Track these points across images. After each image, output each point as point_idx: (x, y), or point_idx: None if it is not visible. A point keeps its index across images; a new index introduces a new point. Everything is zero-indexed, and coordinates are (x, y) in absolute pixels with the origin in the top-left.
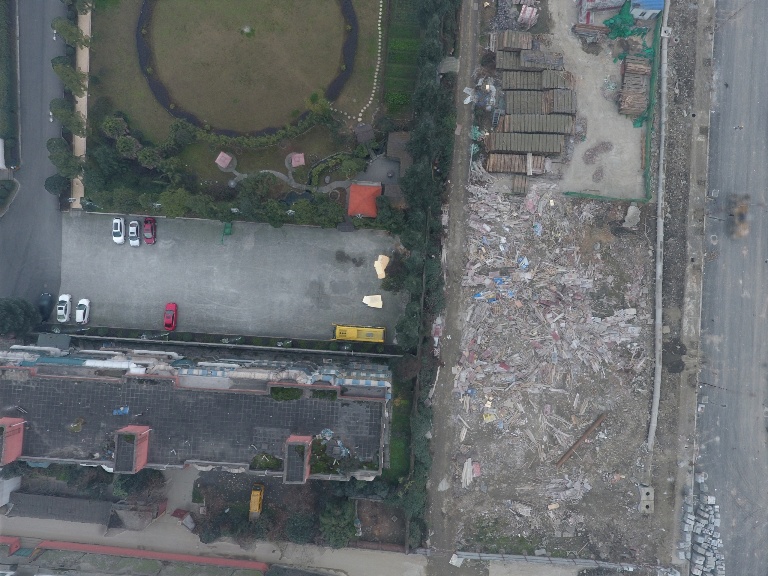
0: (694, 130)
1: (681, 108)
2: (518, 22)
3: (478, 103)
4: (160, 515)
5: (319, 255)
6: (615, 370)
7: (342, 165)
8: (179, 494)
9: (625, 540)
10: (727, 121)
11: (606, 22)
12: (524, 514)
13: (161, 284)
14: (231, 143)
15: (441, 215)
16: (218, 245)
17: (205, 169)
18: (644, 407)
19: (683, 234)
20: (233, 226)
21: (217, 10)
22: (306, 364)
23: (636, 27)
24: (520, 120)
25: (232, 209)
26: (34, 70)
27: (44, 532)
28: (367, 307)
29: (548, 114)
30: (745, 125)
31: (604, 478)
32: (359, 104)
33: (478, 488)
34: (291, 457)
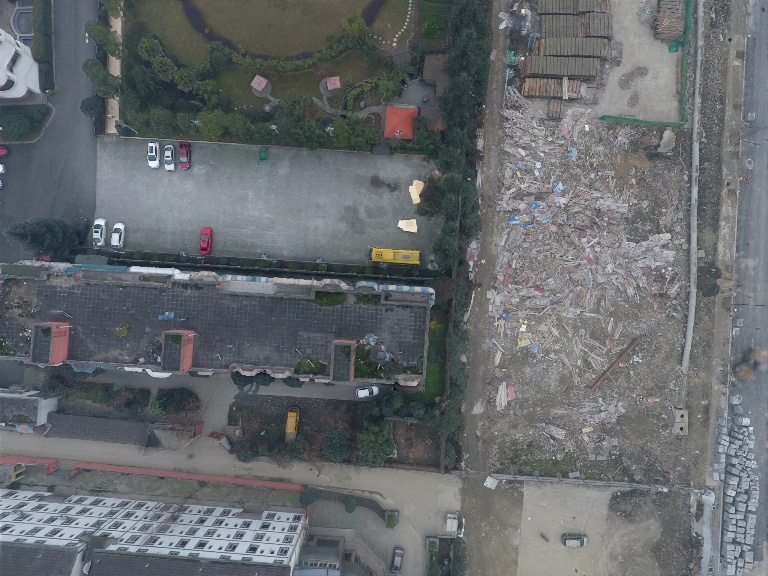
0: (730, 54)
1: (717, 32)
2: None
3: (514, 27)
4: (197, 436)
5: (354, 180)
6: (649, 295)
7: None
8: (215, 417)
9: (659, 463)
10: (763, 45)
11: None
12: (558, 437)
13: (196, 209)
14: (267, 66)
15: (476, 139)
16: (253, 170)
17: (239, 94)
18: (678, 331)
19: (719, 158)
20: (268, 151)
21: None
22: None
23: None
24: (556, 43)
25: (271, 126)
26: None
27: (81, 454)
28: (402, 232)
29: (584, 38)
30: None
31: (638, 402)
32: (394, 29)
33: (512, 411)
34: (337, 358)
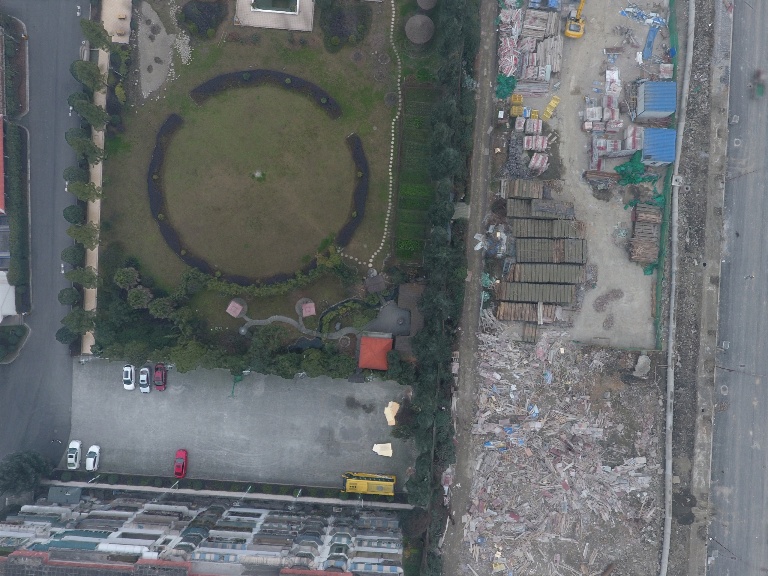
0: (705, 280)
1: (692, 257)
2: (529, 168)
3: (489, 251)
4: None
5: (329, 401)
6: (625, 519)
7: (353, 318)
8: None
9: None
10: (738, 270)
11: (617, 169)
12: None
13: (171, 430)
14: (242, 293)
15: (451, 363)
16: (228, 391)
17: (216, 314)
18: (654, 558)
19: (693, 384)
20: None
21: (228, 154)
22: (316, 520)
23: (647, 175)
24: (531, 270)
25: (243, 371)
26: (45, 214)
27: None
28: (377, 454)
29: (559, 263)
30: (756, 275)
31: None
32: (370, 249)
33: None
34: None
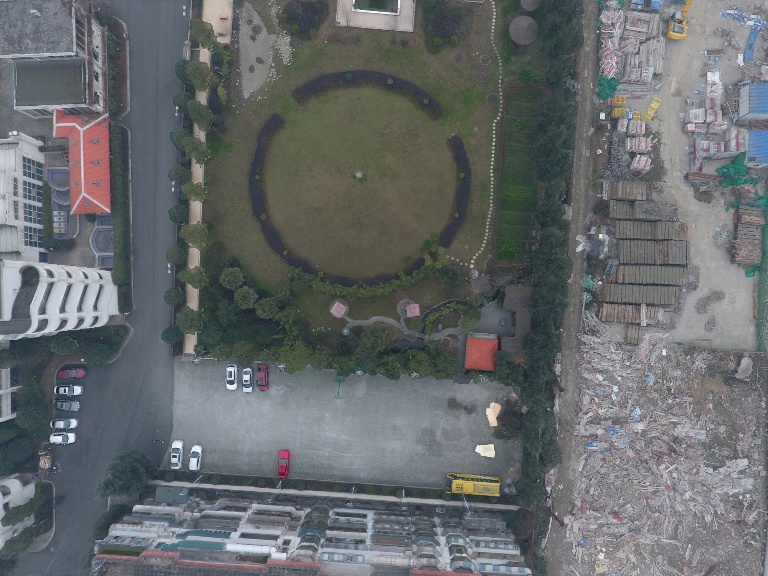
0: None
1: None
2: (631, 170)
3: (592, 252)
4: None
5: (431, 402)
6: (727, 521)
7: None
8: None
9: None
10: None
11: (718, 170)
12: None
13: (273, 430)
14: (347, 293)
15: (554, 365)
16: (330, 391)
17: (317, 315)
18: (757, 560)
19: None
20: None
21: (329, 155)
22: (424, 521)
23: (749, 177)
24: (635, 272)
25: (357, 372)
26: (146, 214)
27: None
28: (479, 455)
29: (662, 265)
30: None
31: None
32: (471, 250)
33: None
34: None
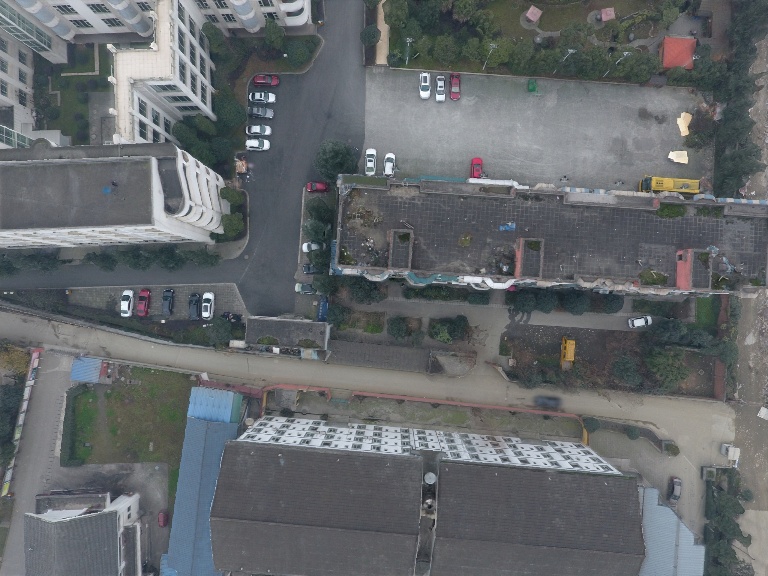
0: None
1: None
2: None
3: None
4: None
5: (622, 112)
6: None
7: None
8: (486, 347)
9: None
10: None
11: None
12: None
13: (465, 140)
14: None
15: None
16: (521, 102)
17: (508, 26)
18: None
19: None
20: None
21: None
22: None
23: None
24: None
25: (569, 50)
26: None
27: (352, 383)
28: (670, 164)
29: None
30: None
31: None
32: None
33: None
34: (694, 265)
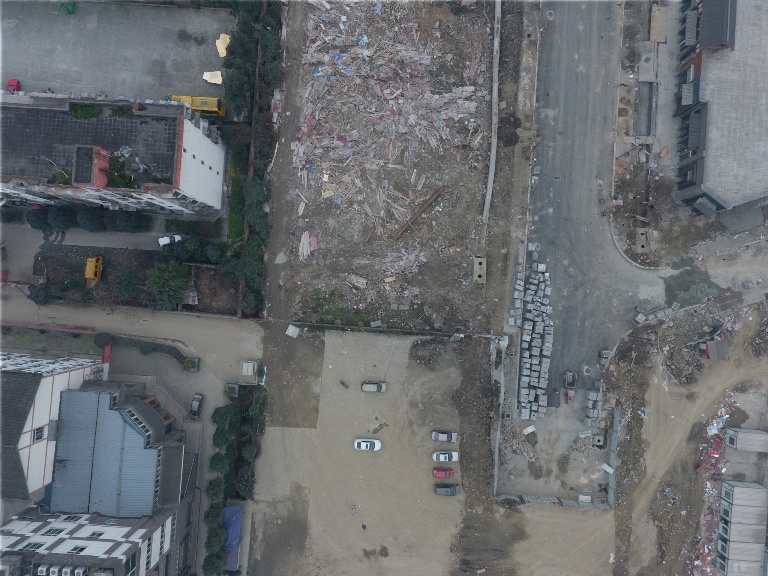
0: None
1: None
2: None
3: None
4: None
5: (161, 34)
6: (453, 146)
7: None
8: (20, 267)
9: (460, 312)
10: None
11: None
12: (359, 285)
13: (4, 62)
14: None
15: None
16: (61, 24)
17: None
18: (479, 181)
19: (520, 10)
20: (76, 5)
21: None
22: None
23: None
24: None
25: None
26: None
27: None
28: (208, 85)
29: None
30: None
31: (440, 252)
32: None
33: (315, 261)
34: (81, 161)
